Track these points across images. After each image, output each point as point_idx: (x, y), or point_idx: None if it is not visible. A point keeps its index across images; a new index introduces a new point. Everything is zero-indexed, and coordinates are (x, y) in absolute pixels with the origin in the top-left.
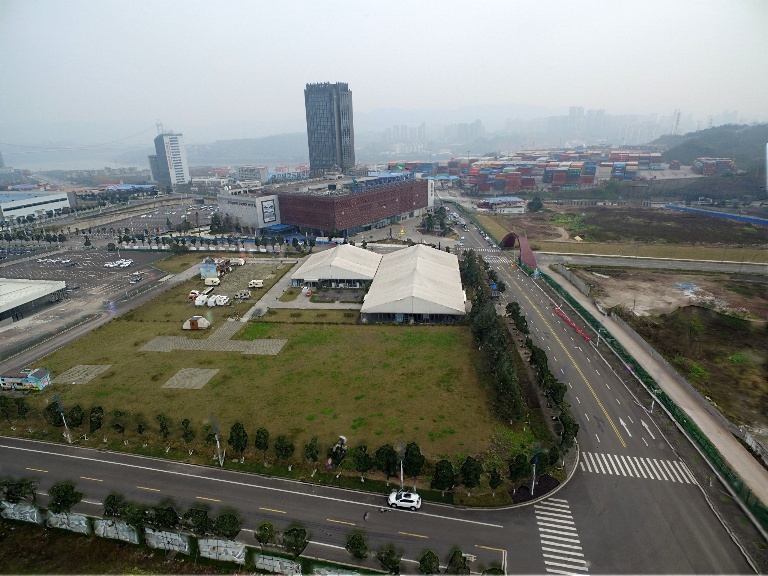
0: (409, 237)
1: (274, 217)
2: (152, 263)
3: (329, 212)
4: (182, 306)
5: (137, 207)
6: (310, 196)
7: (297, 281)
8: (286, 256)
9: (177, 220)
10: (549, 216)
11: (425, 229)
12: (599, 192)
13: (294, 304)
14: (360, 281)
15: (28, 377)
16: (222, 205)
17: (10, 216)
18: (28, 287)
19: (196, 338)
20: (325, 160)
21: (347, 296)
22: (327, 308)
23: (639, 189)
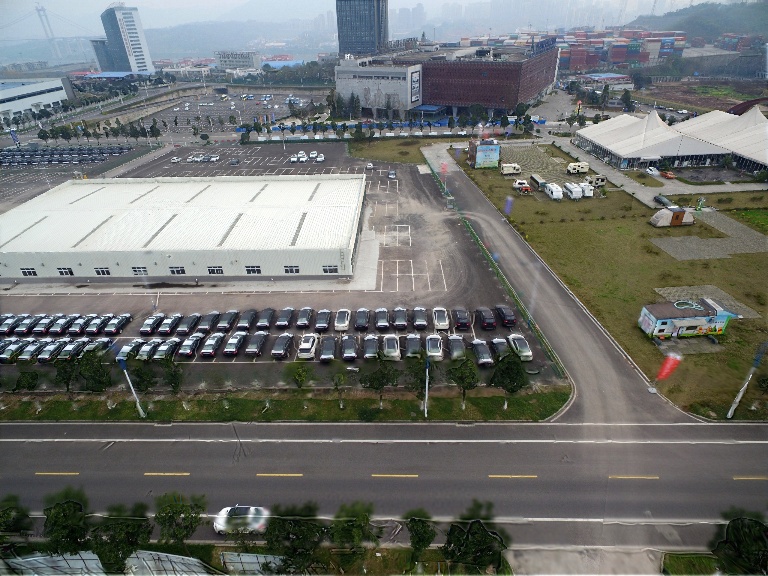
0: (593, 114)
1: (418, 95)
2: (347, 154)
3: (510, 83)
4: (531, 201)
5: (157, 98)
6: (481, 63)
7: (629, 161)
8: (518, 137)
9: (232, 111)
10: (689, 89)
11: (605, 104)
12: (667, 69)
13: (678, 189)
14: (713, 156)
15: (717, 314)
16: (343, 81)
17: (6, 111)
18: (319, 185)
19: (715, 236)
20: (359, 36)
21: (721, 175)
22: (734, 190)
23: (749, 59)
